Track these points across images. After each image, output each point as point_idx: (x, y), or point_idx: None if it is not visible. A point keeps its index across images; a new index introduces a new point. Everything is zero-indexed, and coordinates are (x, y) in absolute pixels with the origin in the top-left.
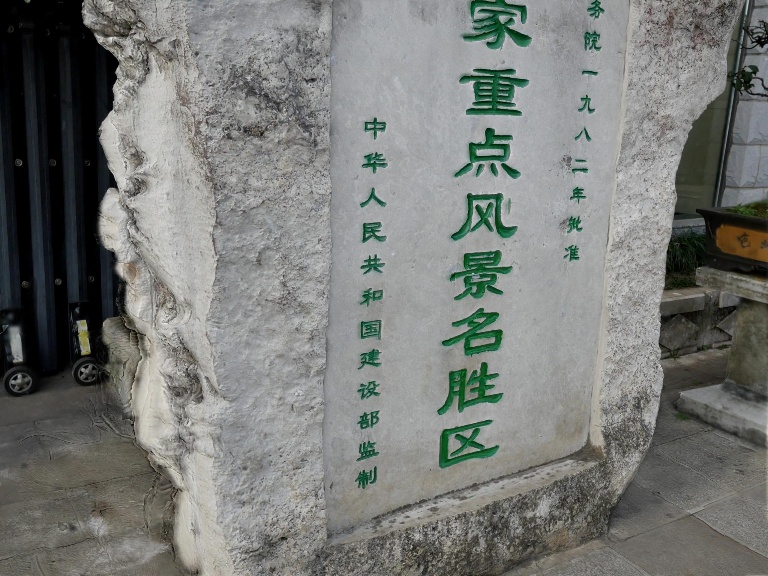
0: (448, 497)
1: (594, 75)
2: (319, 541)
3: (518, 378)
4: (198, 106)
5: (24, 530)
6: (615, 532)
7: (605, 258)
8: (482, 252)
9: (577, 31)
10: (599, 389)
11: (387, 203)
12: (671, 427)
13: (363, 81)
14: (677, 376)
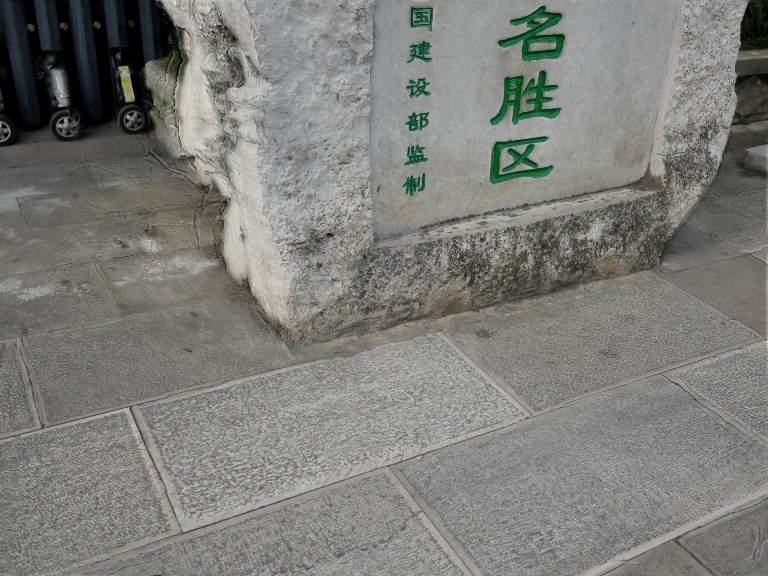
0: (498, 214)
1: None
2: (366, 241)
3: (578, 93)
4: None
5: (81, 243)
6: (667, 265)
7: None
8: None
9: None
10: (665, 114)
11: None
12: (736, 182)
13: None
14: (747, 139)
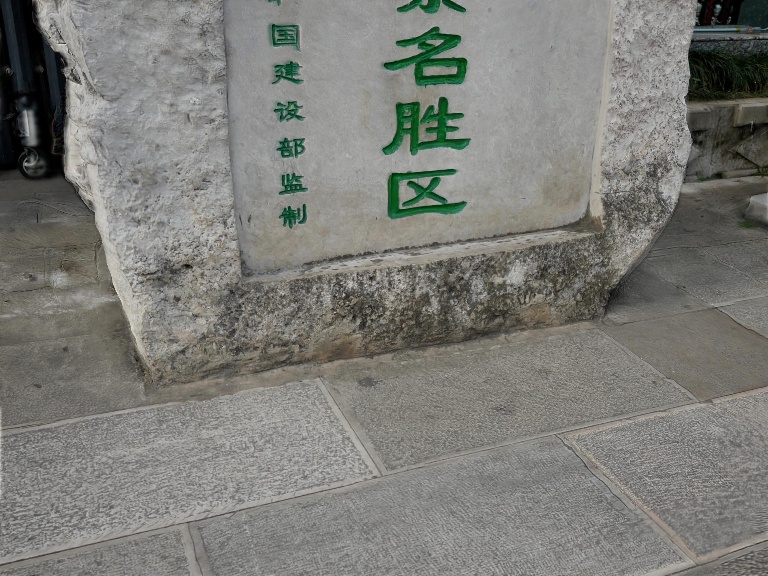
0: (400, 252)
1: None
2: (232, 275)
3: (490, 122)
4: None
5: None
6: (613, 317)
7: None
8: None
9: None
10: (601, 148)
11: None
12: (730, 233)
13: None
14: (761, 190)
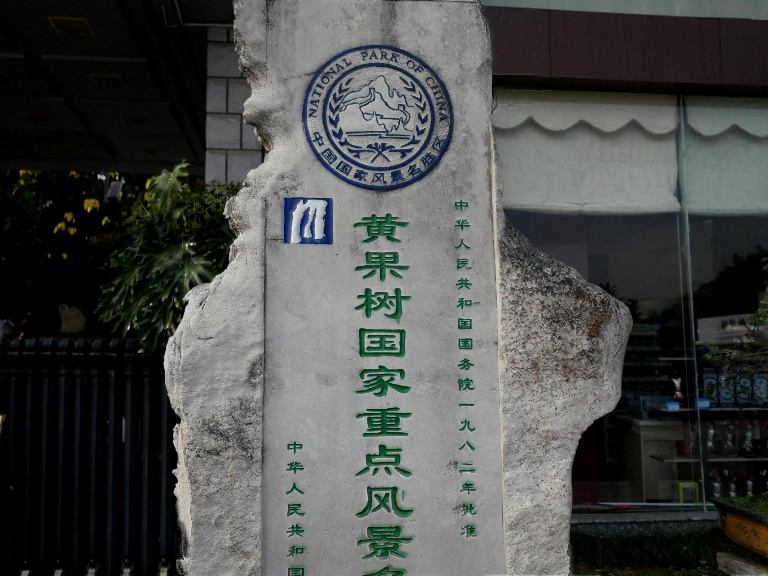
0: None
1: (471, 406)
2: None
3: None
4: (186, 440)
5: None
6: None
7: (503, 537)
8: (384, 527)
9: (451, 379)
10: None
11: (305, 492)
12: None
13: (286, 422)
14: None
